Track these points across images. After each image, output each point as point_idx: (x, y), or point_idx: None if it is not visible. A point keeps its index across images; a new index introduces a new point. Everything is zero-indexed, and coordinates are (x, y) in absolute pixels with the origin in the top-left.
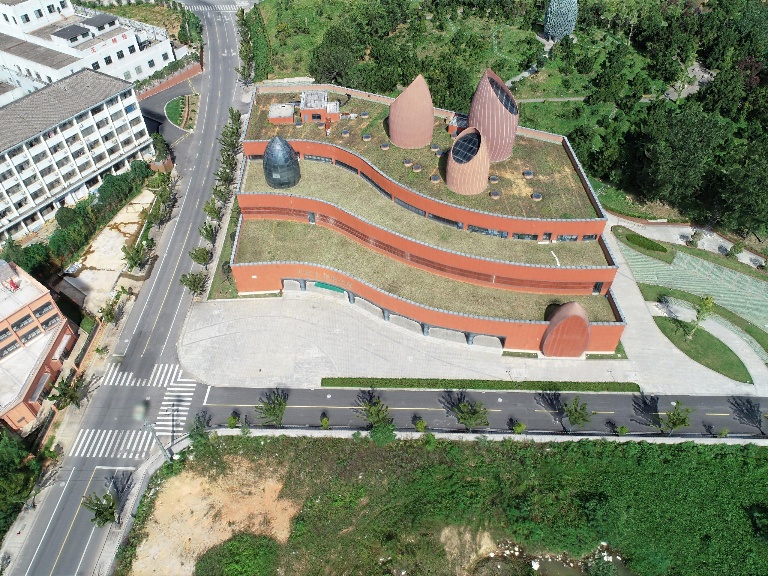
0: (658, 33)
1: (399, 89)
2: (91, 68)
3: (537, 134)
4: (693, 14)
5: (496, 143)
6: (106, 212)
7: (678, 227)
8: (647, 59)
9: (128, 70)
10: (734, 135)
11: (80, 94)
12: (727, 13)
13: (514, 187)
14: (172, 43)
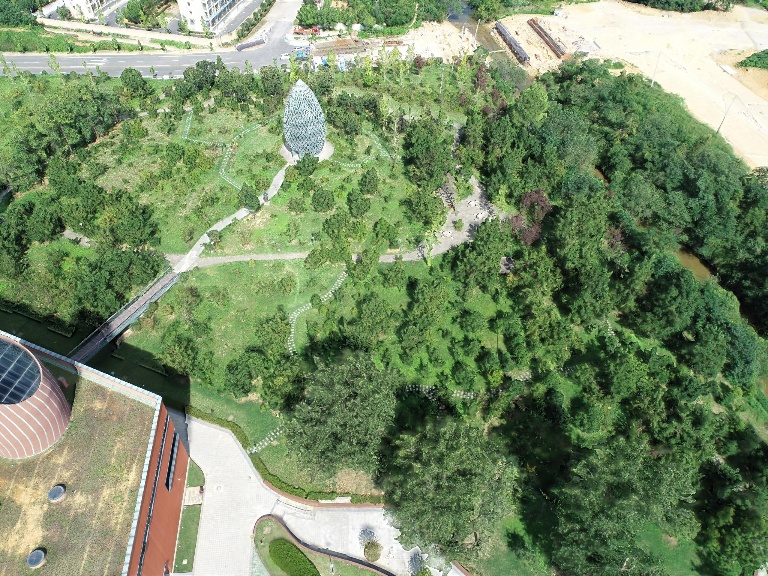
0: (418, 156)
1: (66, 236)
2: None
3: (125, 387)
4: (498, 108)
5: (2, 441)
6: None
7: (365, 511)
8: (412, 187)
9: None
10: (489, 325)
11: None
12: (524, 118)
13: (16, 528)
14: None
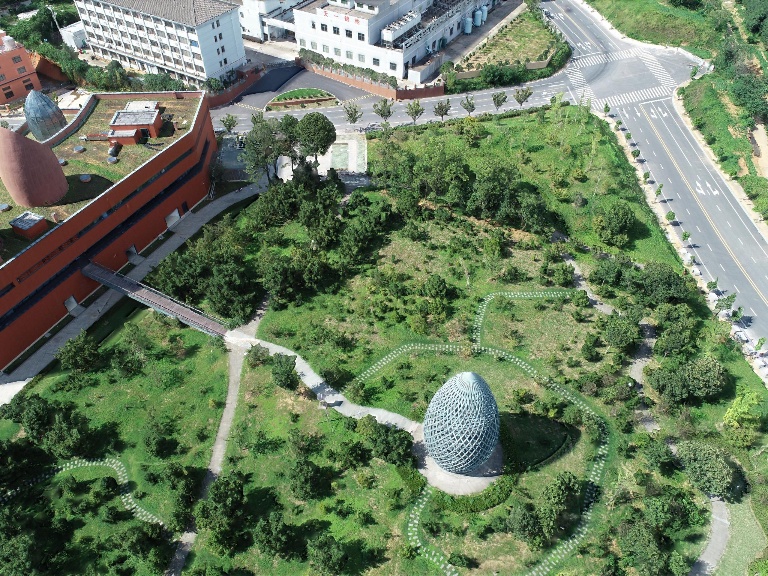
0: None
1: None
2: (320, 26)
3: None
4: None
5: None
6: (138, 89)
7: None
8: None
9: (352, 51)
10: None
11: (174, 8)
12: None
13: None
14: (424, 64)
